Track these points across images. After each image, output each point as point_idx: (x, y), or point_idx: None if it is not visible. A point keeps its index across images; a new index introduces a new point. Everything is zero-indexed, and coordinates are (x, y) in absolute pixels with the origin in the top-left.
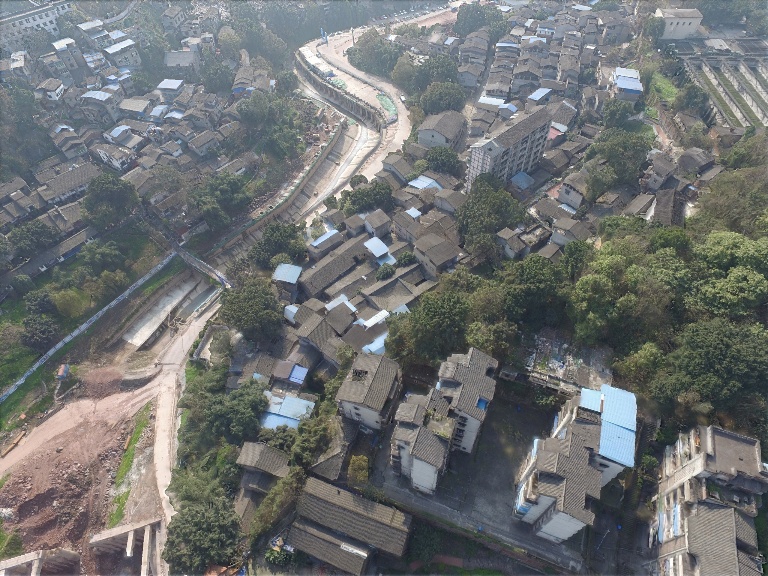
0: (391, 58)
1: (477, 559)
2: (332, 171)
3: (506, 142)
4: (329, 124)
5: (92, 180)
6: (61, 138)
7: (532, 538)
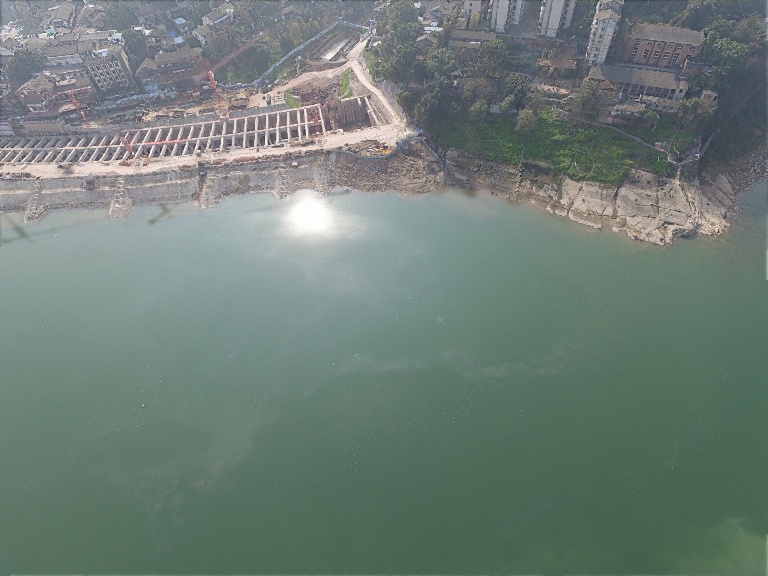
0: None
1: (523, 55)
2: None
3: None
4: None
5: None
6: None
7: (545, 38)
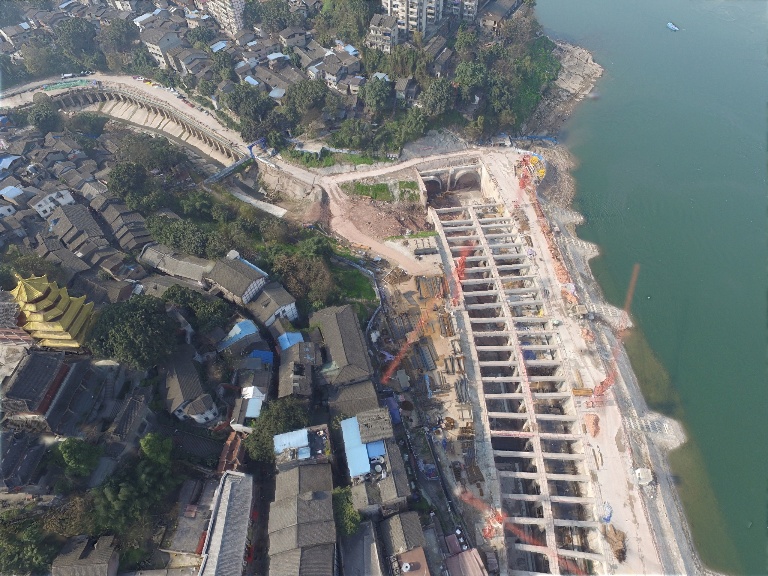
0: (5, 63)
1: None
2: None
3: None
4: None
5: (116, 178)
6: None
7: None
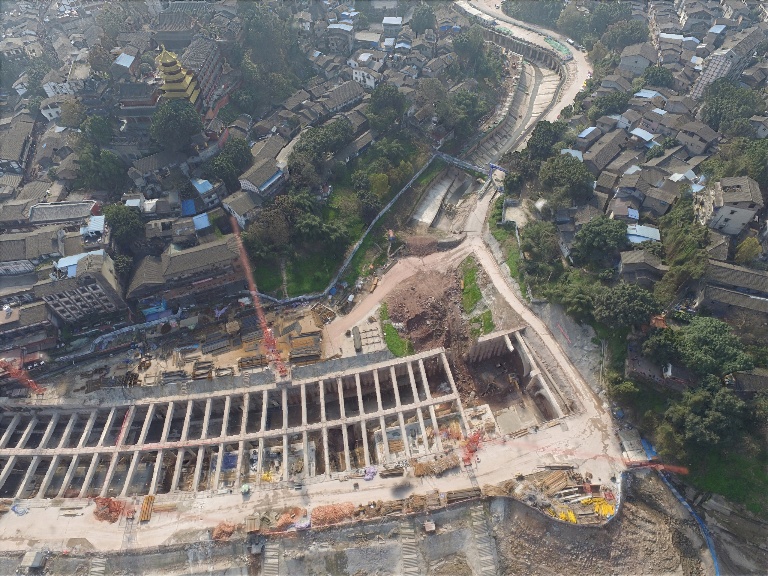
0: (554, 7)
1: None
2: (525, 99)
3: (740, 52)
4: (511, 62)
5: (377, 89)
6: (324, 60)
7: None
